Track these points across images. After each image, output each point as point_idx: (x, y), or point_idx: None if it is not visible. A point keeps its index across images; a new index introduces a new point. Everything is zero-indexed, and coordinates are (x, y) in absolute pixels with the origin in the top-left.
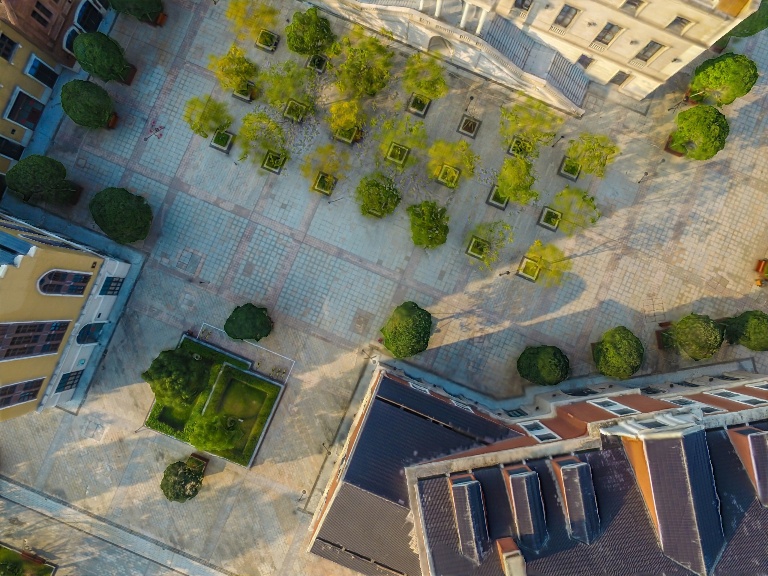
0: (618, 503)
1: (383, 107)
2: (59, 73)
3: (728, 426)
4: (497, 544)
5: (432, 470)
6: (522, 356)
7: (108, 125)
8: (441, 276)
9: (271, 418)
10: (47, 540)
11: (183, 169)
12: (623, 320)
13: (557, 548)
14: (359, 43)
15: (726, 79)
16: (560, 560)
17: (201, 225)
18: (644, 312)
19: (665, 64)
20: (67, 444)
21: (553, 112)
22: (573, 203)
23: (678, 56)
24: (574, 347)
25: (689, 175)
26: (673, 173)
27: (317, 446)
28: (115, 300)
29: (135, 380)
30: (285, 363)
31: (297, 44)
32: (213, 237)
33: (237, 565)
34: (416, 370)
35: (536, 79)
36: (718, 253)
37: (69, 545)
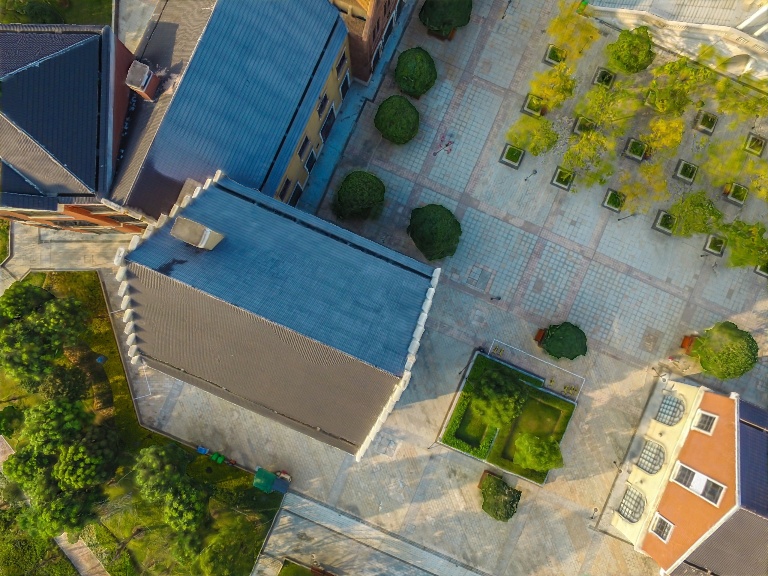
0: None
1: None
2: (349, 86)
3: None
4: None
5: None
6: None
7: None
8: (729, 295)
9: None
10: (335, 556)
11: (472, 184)
12: None
13: None
14: None
15: None
16: None
17: (491, 241)
18: None
19: None
20: None
21: None
22: None
23: None
24: None
25: None
26: None
27: (608, 464)
28: None
29: (427, 396)
30: (576, 380)
31: (629, 63)
32: (503, 253)
33: None
34: None
35: None
36: None
37: (357, 561)
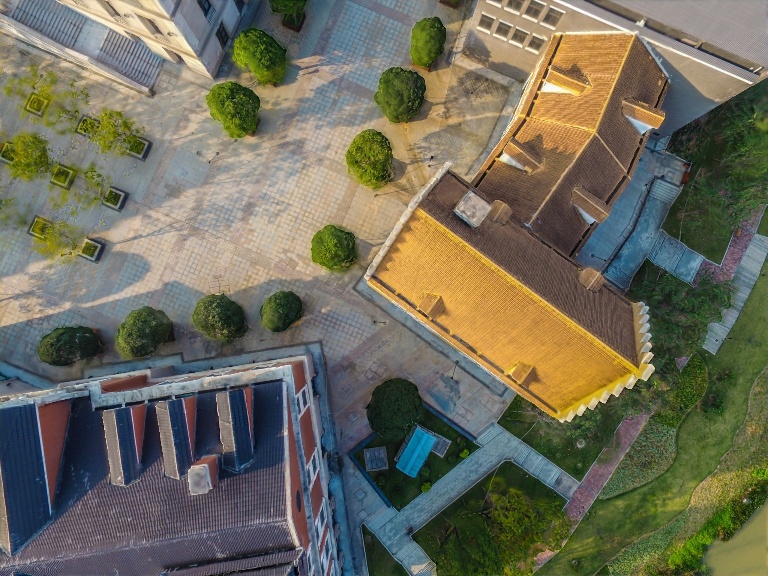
0: None
1: None
2: None
3: (126, 403)
4: None
5: None
6: None
7: None
8: (1, 256)
9: None
10: None
11: None
12: (188, 302)
13: None
14: None
15: (242, 55)
16: None
17: None
18: (210, 294)
19: (175, 39)
20: None
21: (125, 91)
22: (141, 183)
23: (169, 30)
24: None
25: (261, 155)
26: (245, 153)
27: None
28: None
29: None
30: None
31: None
32: None
33: None
34: None
35: (78, 55)
36: (288, 234)
37: None
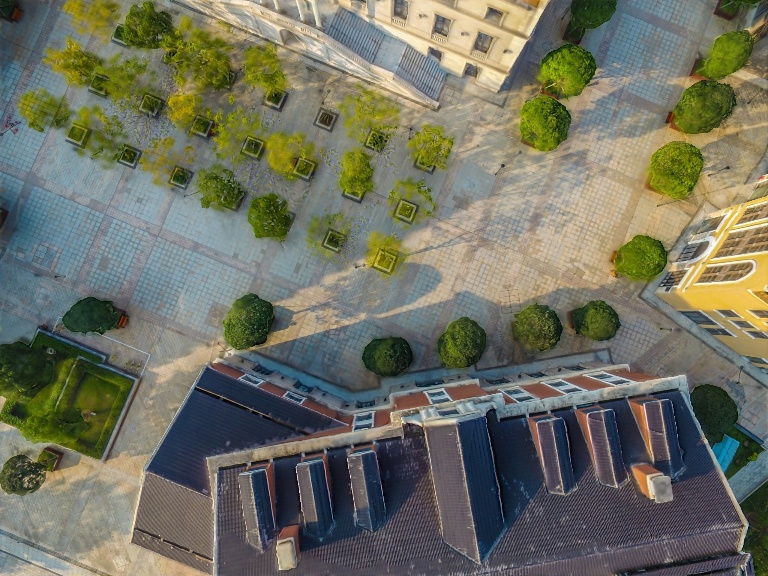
0: (409, 491)
1: (240, 101)
2: None
3: (530, 414)
4: None
5: (233, 459)
6: (366, 347)
7: None
8: (297, 269)
9: (126, 411)
10: None
11: (39, 164)
12: (479, 312)
13: (341, 535)
14: (216, 37)
15: (563, 70)
16: (341, 547)
17: (57, 220)
18: (500, 303)
19: (501, 55)
20: None
21: (410, 105)
22: None
23: (508, 47)
24: (430, 339)
25: (546, 167)
26: (530, 165)
27: None
28: None
29: None
30: (140, 356)
31: (132, 38)
32: (69, 231)
33: (92, 558)
34: (272, 363)
35: (383, 72)
36: (574, 244)
37: None
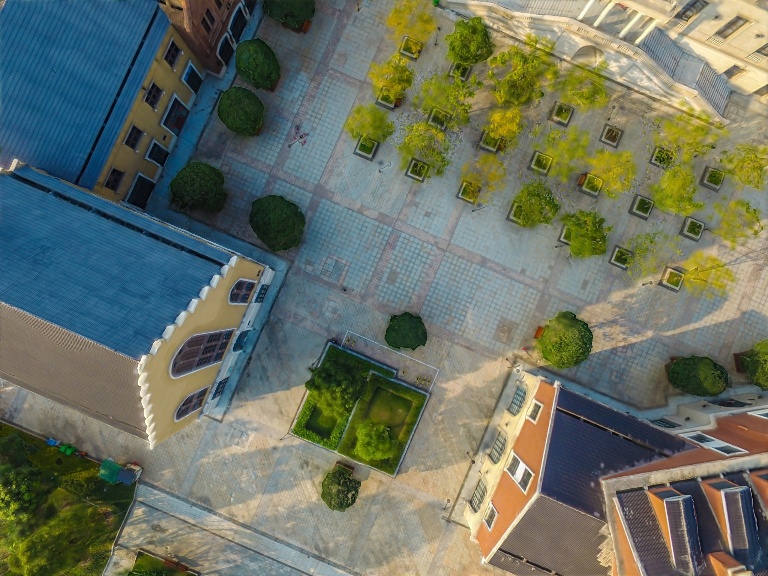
0: None
1: (526, 116)
2: (203, 79)
3: None
4: (712, 559)
5: (630, 483)
6: (677, 367)
7: (254, 132)
8: (584, 285)
9: (416, 426)
10: (189, 547)
11: (327, 176)
12: (765, 331)
13: None
14: (501, 51)
15: None
16: None
17: (345, 233)
18: None
19: None
20: (212, 451)
21: (695, 122)
22: (715, 213)
23: None
24: (716, 357)
25: None
26: None
27: (461, 455)
28: (260, 307)
29: (280, 387)
30: (429, 371)
31: (462, 53)
32: (357, 245)
33: (382, 573)
34: (559, 379)
35: (688, 89)
36: None
37: (211, 552)
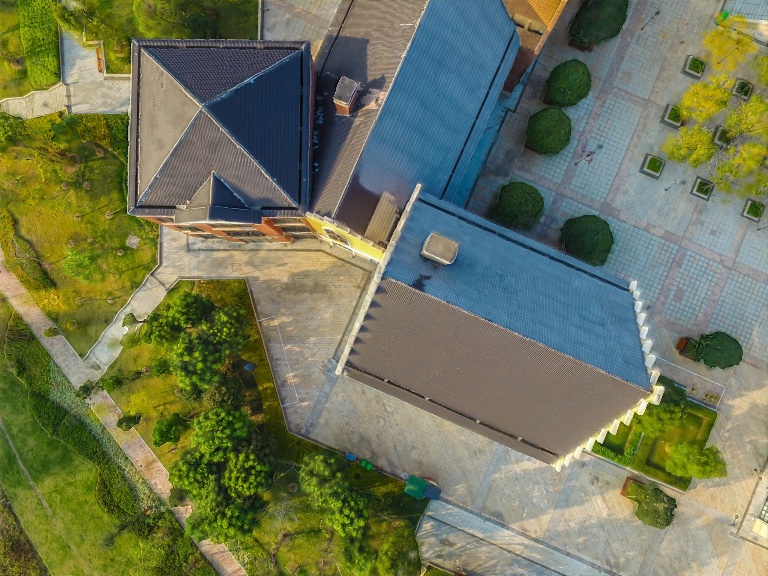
0: None
1: None
2: None
3: None
4: None
5: None
6: None
7: None
8: None
9: None
10: (478, 561)
11: (613, 194)
12: None
13: None
14: None
15: None
16: None
17: (632, 250)
18: None
19: None
20: (504, 467)
21: None
22: None
23: None
24: None
25: None
26: None
27: (748, 471)
28: None
29: None
30: (716, 389)
31: None
32: (644, 262)
33: None
34: None
35: None
36: None
37: (499, 566)
